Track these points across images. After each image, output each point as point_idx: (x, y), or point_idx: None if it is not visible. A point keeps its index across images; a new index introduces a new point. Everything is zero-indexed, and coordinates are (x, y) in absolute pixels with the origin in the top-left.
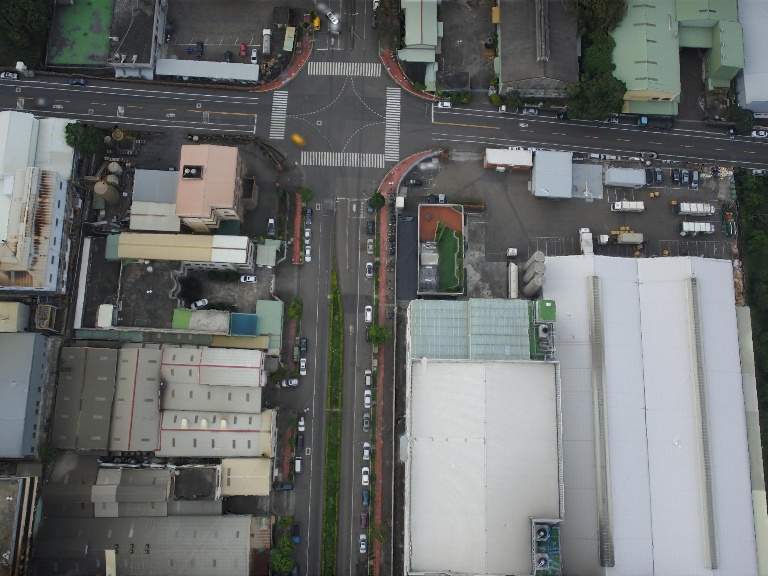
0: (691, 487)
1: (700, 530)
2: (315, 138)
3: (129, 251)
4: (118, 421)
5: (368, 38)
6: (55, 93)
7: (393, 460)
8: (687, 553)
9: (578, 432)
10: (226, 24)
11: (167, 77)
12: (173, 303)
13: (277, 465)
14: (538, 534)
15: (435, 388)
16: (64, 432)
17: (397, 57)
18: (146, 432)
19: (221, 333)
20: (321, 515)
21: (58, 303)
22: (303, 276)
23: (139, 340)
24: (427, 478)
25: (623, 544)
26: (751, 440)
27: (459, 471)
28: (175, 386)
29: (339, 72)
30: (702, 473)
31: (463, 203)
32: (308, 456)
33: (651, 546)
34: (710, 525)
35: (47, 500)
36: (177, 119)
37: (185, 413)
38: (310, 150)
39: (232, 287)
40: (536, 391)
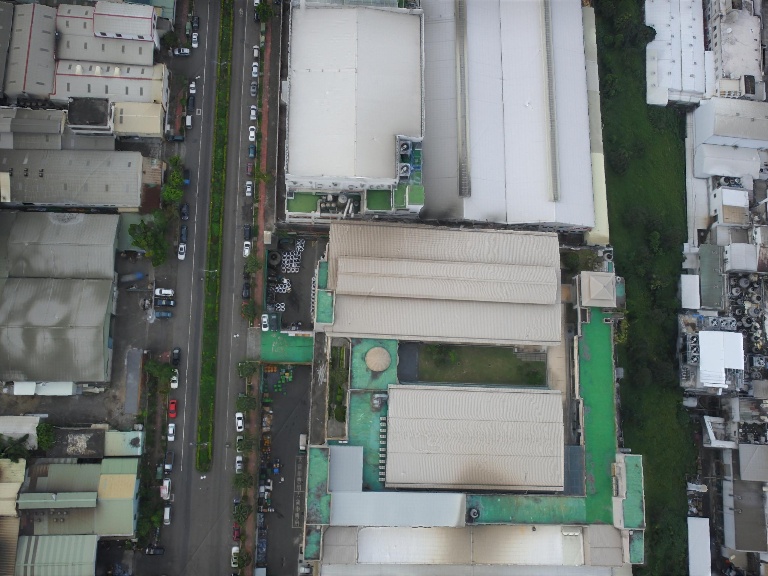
0: (539, 138)
1: (545, 172)
2: None
3: None
4: (13, 66)
5: None
6: None
7: (278, 119)
8: (534, 191)
9: (443, 93)
10: None
11: None
12: None
13: (169, 122)
14: (401, 147)
15: (313, 29)
16: None
17: None
18: (41, 77)
19: None
20: (210, 165)
21: None
22: None
23: None
24: (304, 102)
25: (480, 183)
26: (592, 113)
27: (333, 98)
28: (70, 38)
29: None
30: (548, 124)
31: None
32: (199, 116)
33: (504, 189)
34: (553, 165)
35: None
36: None
37: (80, 63)
38: None
39: None
40: (403, 36)
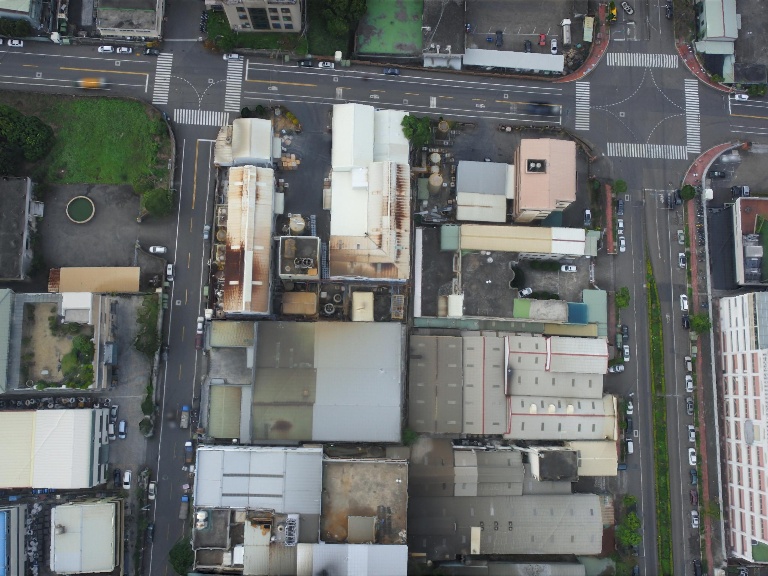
0: None
1: None
2: (619, 129)
3: (472, 243)
4: (469, 406)
5: (663, 29)
6: (371, 83)
7: (718, 442)
8: None
9: None
10: (523, 13)
11: (472, 67)
12: (512, 293)
13: None
14: None
15: None
16: (421, 417)
17: (694, 49)
18: (496, 416)
19: (558, 322)
20: (653, 493)
21: (401, 292)
22: (618, 266)
23: (475, 328)
24: None
25: None
26: None
27: None
28: (521, 373)
29: (638, 63)
30: None
31: (766, 195)
32: (637, 438)
33: None
34: None
35: (413, 481)
36: (487, 110)
37: (530, 398)
38: (615, 141)
39: (552, 276)
40: None
